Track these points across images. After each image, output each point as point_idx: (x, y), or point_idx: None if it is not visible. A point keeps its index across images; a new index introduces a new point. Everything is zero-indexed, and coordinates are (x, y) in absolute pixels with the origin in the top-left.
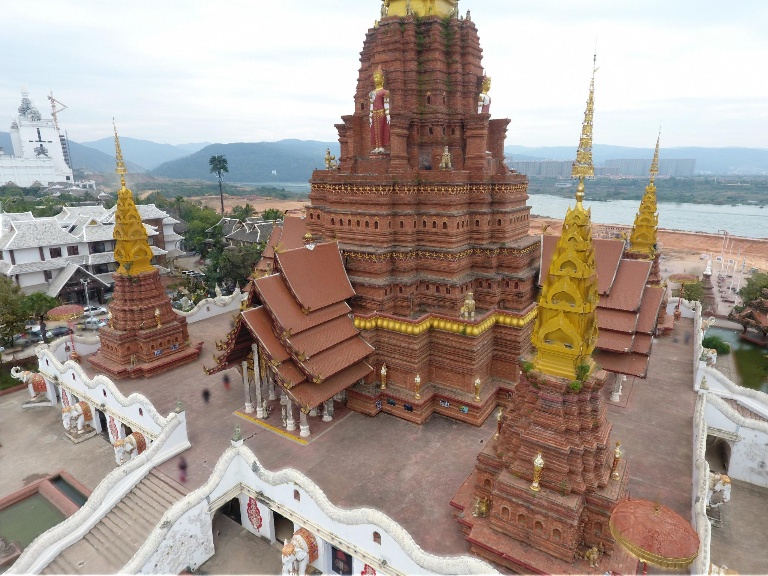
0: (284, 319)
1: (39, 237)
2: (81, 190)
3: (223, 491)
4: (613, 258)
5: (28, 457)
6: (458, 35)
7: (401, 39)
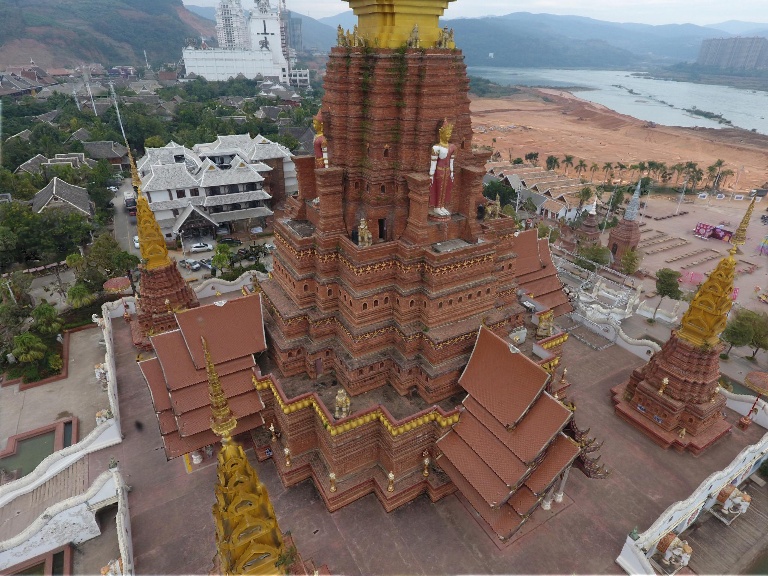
0: (171, 374)
1: (168, 180)
2: (279, 90)
3: (102, 498)
4: (532, 389)
5: (73, 394)
6: (413, 70)
7: (342, 78)
